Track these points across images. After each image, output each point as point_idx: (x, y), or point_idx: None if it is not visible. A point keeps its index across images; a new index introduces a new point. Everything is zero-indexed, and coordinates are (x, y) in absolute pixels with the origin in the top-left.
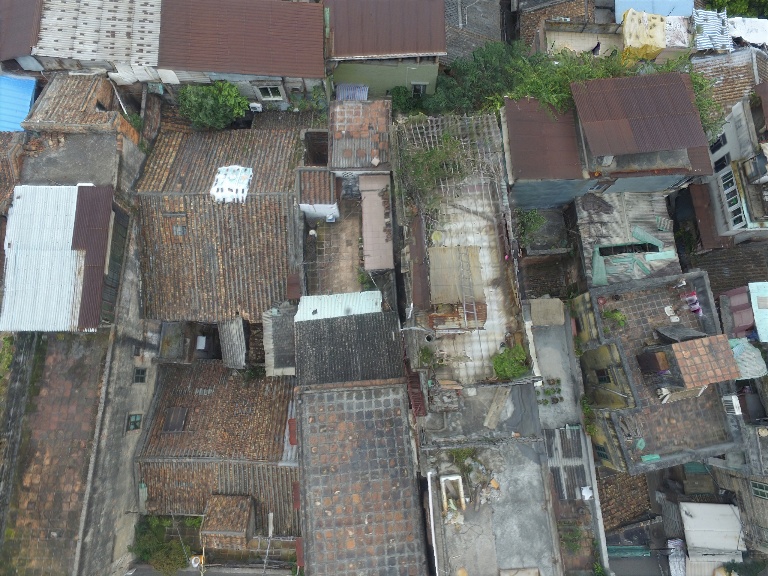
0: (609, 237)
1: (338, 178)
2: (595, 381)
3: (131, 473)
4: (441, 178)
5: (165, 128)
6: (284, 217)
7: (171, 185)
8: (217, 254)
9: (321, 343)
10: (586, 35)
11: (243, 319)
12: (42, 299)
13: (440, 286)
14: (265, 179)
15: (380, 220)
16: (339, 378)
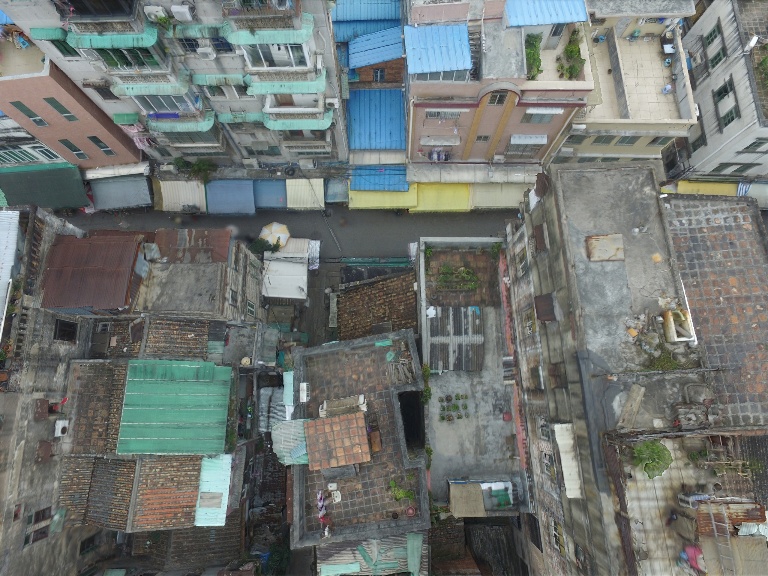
0: None
1: None
2: None
3: None
4: None
5: None
6: None
7: None
8: None
9: None
10: None
11: None
12: None
13: (759, 560)
14: None
15: None
16: (761, 439)
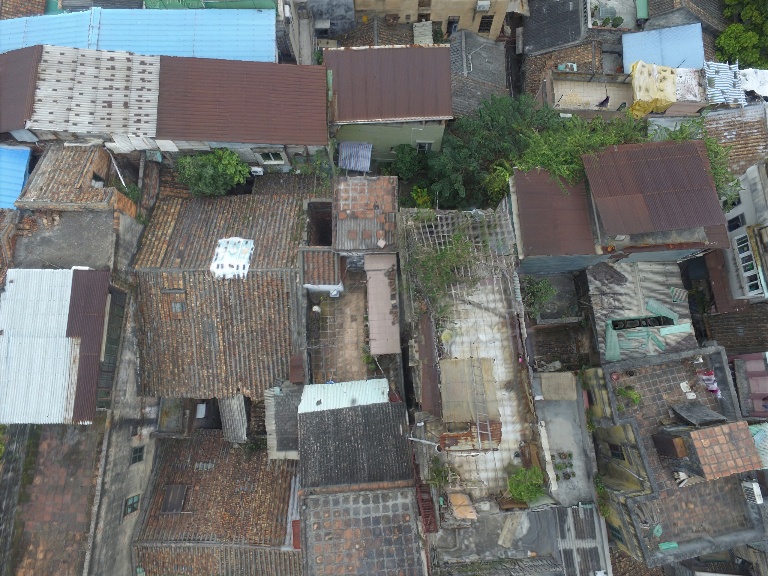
0: (622, 309)
1: (342, 257)
2: (608, 454)
3: (128, 559)
4: (452, 283)
5: (164, 193)
6: (286, 293)
7: (170, 259)
8: (217, 331)
9: (326, 437)
10: (594, 84)
11: (244, 394)
12: (35, 389)
13: (452, 402)
14: (267, 252)
15: (386, 301)
16: (345, 477)
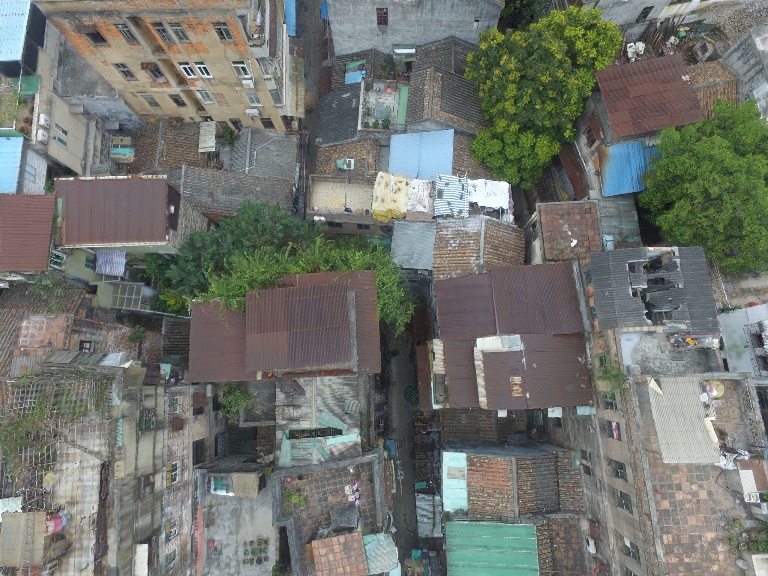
0: (298, 420)
1: None
2: None
3: None
4: (24, 446)
5: None
6: None
7: None
8: None
9: None
10: (354, 186)
11: None
12: None
13: (6, 550)
14: None
15: None
16: None
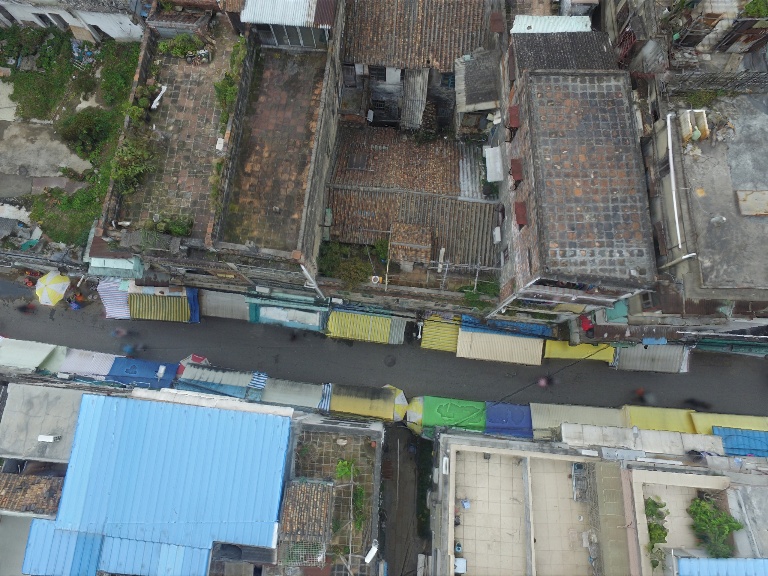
0: None
1: None
2: None
3: (323, 194)
4: None
5: None
6: None
7: None
8: (418, 1)
9: (538, 49)
10: None
11: (429, 73)
12: None
13: None
14: None
15: None
16: None
